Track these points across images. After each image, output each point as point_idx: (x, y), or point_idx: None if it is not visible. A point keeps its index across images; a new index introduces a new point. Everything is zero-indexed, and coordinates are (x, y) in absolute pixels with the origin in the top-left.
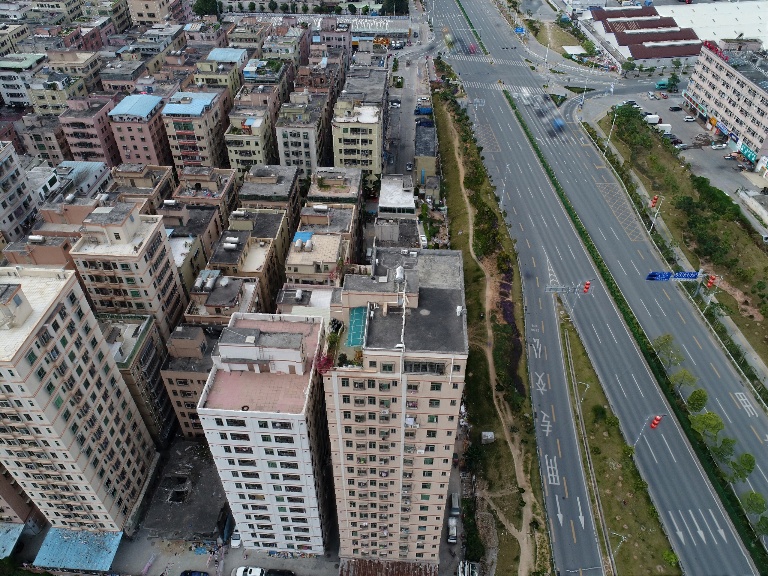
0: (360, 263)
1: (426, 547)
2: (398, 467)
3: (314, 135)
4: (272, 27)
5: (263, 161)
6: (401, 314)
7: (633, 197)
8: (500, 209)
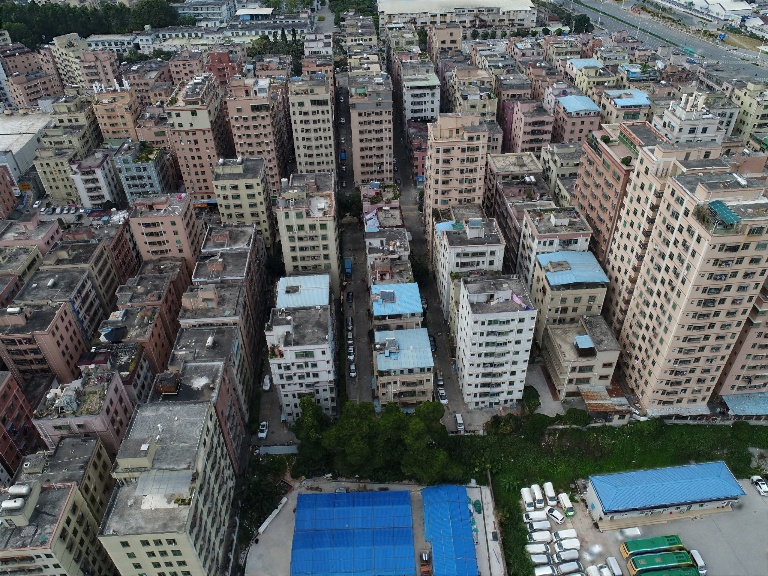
0: None
1: None
2: None
3: None
4: None
5: None
6: None
7: None
8: None
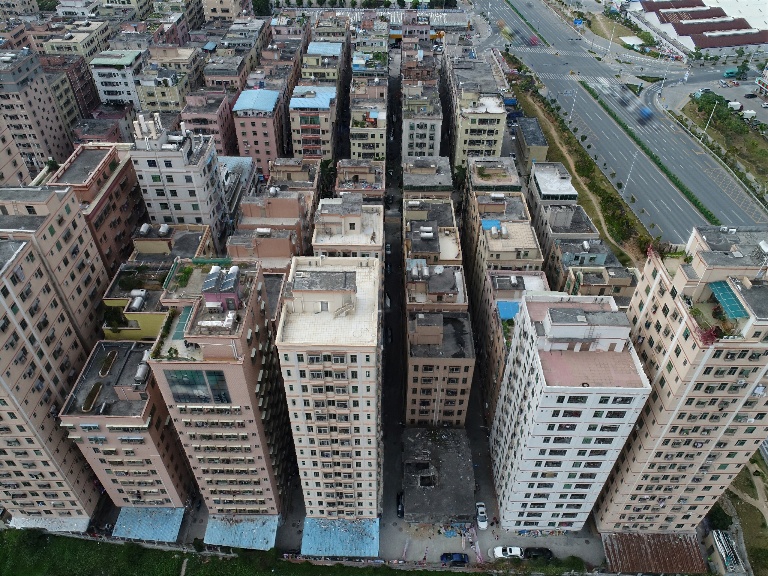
0: None
1: (691, 517)
2: (715, 437)
3: None
4: None
5: (385, 154)
6: (763, 287)
7: (743, 181)
8: (621, 196)
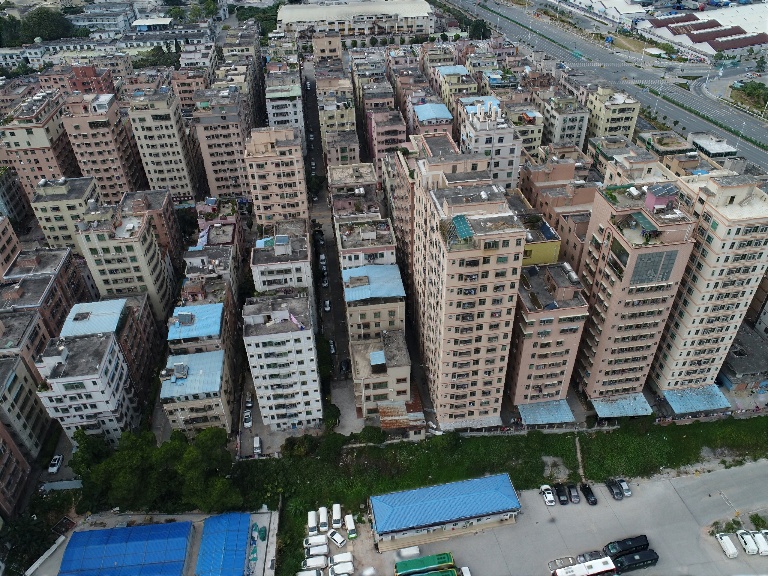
0: None
1: None
2: None
3: None
4: None
5: None
6: None
7: None
8: None
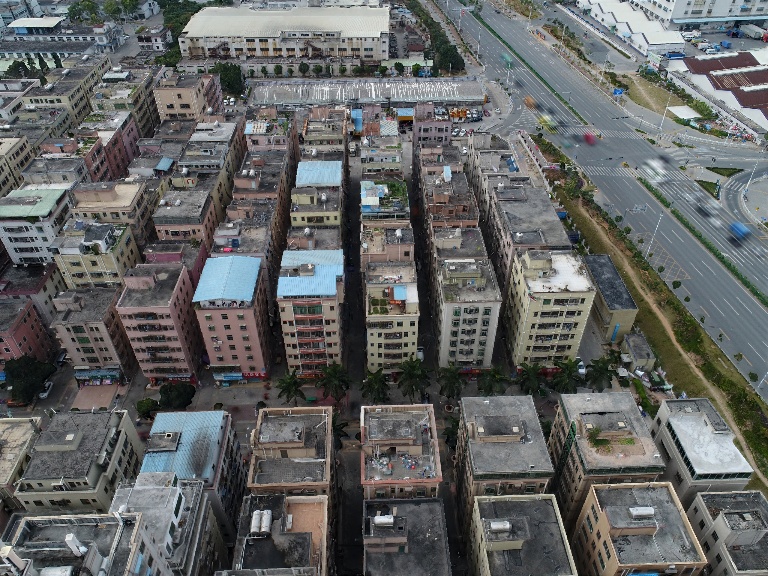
0: None
1: None
2: None
3: None
4: None
5: (416, 343)
6: None
7: None
8: (753, 387)
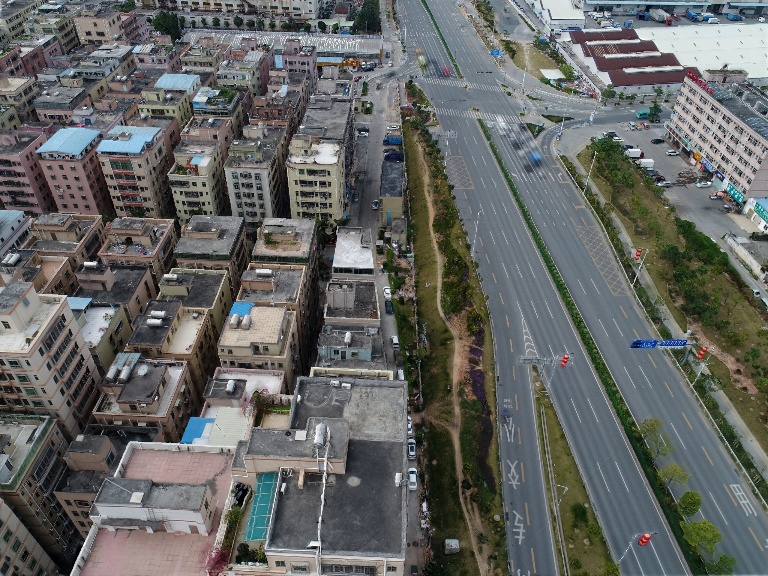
0: (315, 323)
1: None
2: None
3: (267, 176)
4: (231, 49)
5: (212, 203)
6: (322, 485)
7: (614, 243)
8: (472, 257)
